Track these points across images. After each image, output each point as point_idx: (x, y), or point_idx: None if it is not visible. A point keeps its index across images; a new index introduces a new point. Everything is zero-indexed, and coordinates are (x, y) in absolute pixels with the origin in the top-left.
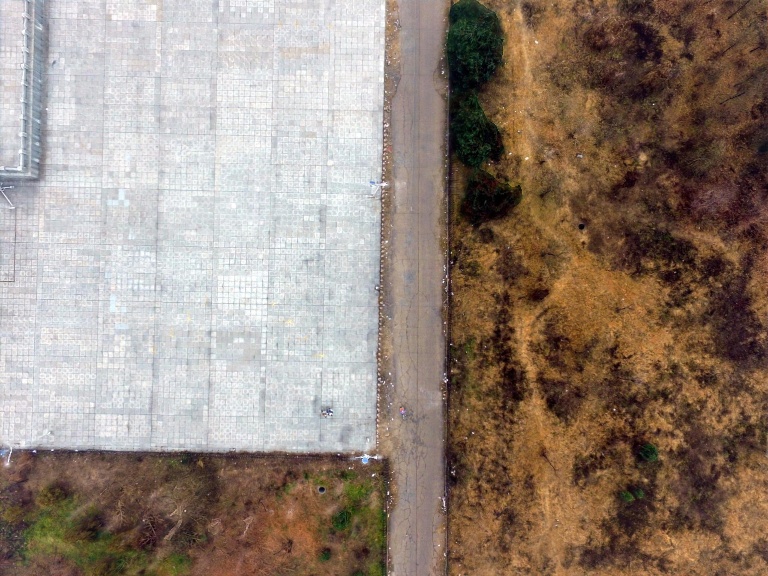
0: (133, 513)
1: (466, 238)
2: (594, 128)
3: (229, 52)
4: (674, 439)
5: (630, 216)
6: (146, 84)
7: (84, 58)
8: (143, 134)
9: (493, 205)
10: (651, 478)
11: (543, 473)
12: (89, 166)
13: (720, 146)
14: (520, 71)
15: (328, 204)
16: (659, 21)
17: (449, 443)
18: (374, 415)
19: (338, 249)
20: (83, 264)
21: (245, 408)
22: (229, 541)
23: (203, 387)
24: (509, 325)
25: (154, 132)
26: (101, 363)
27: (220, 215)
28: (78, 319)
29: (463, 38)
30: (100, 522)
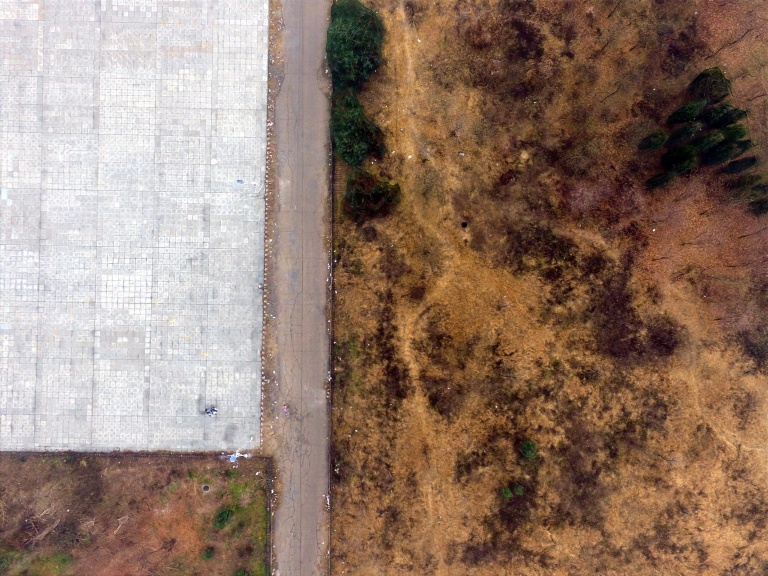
0: (15, 513)
1: (349, 236)
2: (476, 126)
3: (112, 51)
4: (555, 436)
5: (512, 214)
6: (28, 83)
7: None
8: (25, 133)
9: (371, 203)
10: (533, 474)
11: (425, 470)
12: None
13: (601, 144)
14: (403, 70)
15: (212, 203)
16: (540, 19)
17: (332, 441)
18: (258, 413)
19: (222, 248)
20: None
21: (129, 407)
22: (113, 540)
23: (87, 387)
24: (392, 323)
25: (37, 131)
26: None
27: (103, 214)
28: None
29: (338, 37)
30: None
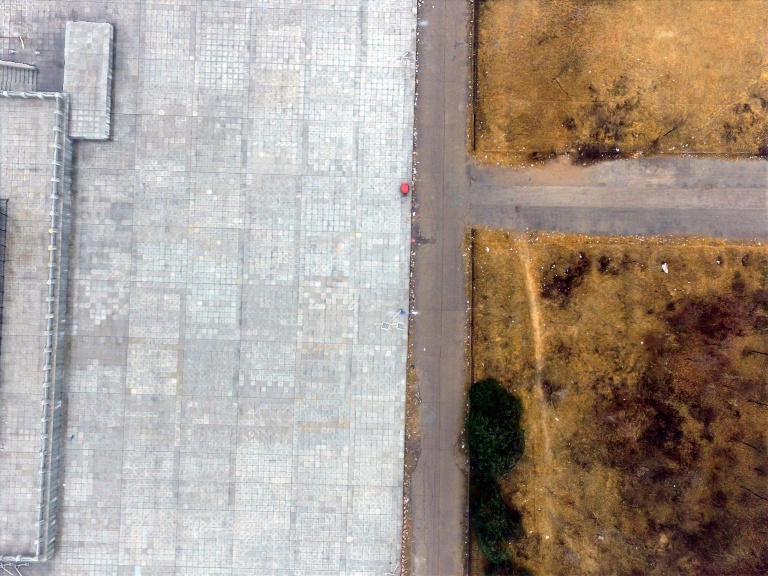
0: None
1: None
2: (615, 508)
3: (249, 426)
4: None
5: None
6: (165, 459)
7: (103, 432)
8: (161, 510)
9: None
10: None
11: None
12: (105, 543)
13: (741, 530)
14: (541, 448)
15: None
16: (679, 401)
17: None
18: None
19: None
20: None
21: None
22: None
23: None
24: None
25: (172, 508)
26: None
27: None
28: None
29: (485, 440)
30: None
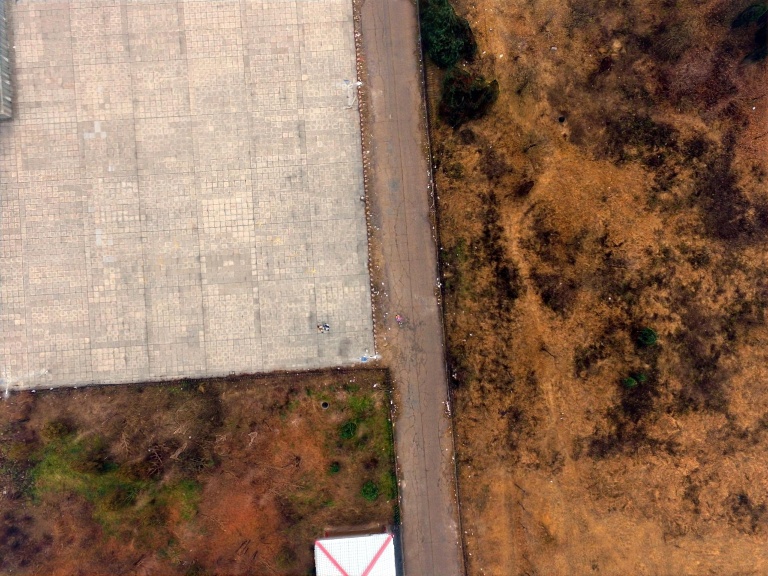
0: (138, 444)
1: (447, 141)
2: (566, 19)
3: None
4: (671, 322)
5: (609, 104)
6: (112, 13)
7: None
8: (114, 64)
9: (471, 102)
10: (652, 363)
11: (544, 368)
12: (62, 101)
13: (693, 26)
14: None
15: (306, 119)
16: None
17: (448, 347)
18: (371, 326)
19: (320, 163)
20: (65, 200)
21: (241, 330)
22: (237, 464)
23: (197, 313)
24: (498, 224)
25: (124, 61)
26: (92, 298)
27: (198, 139)
28: (65, 256)
29: None
30: (106, 455)
